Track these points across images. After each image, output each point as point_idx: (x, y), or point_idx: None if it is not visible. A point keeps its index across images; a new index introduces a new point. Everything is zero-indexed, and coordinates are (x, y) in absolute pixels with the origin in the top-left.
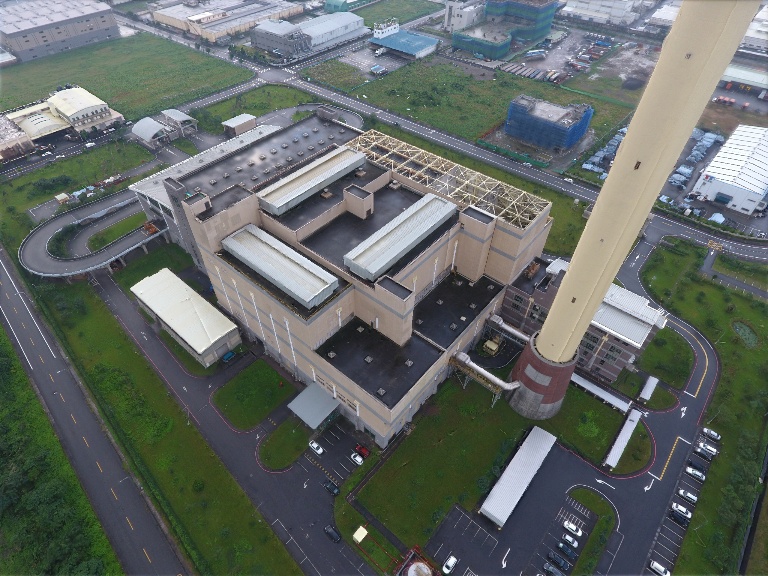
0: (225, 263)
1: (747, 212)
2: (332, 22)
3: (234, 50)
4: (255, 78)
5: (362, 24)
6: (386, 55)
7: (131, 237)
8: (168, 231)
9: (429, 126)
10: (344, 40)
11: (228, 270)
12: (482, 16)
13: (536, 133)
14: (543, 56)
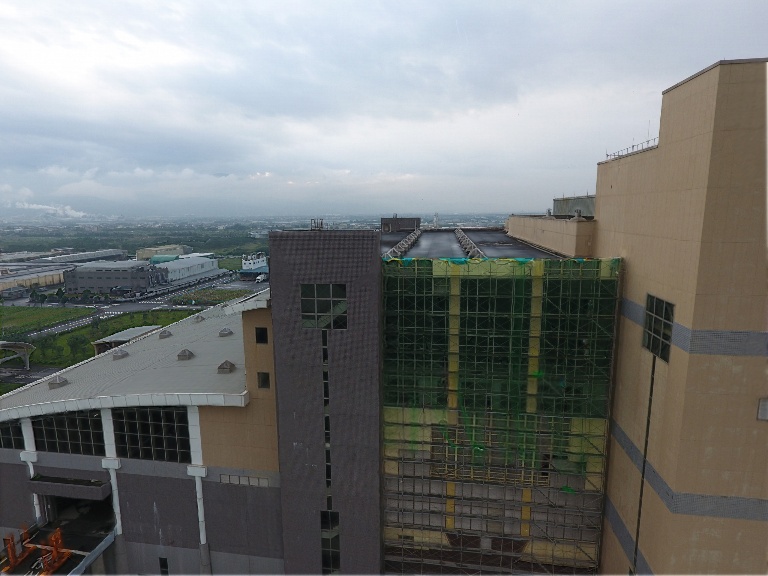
0: None
1: None
2: (183, 262)
3: None
4: (100, 312)
5: (216, 265)
6: None
7: None
8: (113, 545)
9: None
10: (204, 277)
11: None
12: None
13: None
14: None
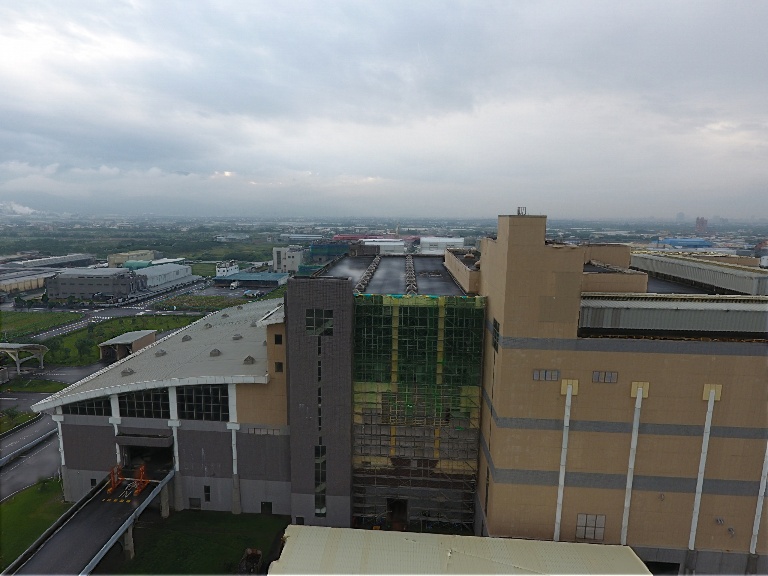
0: (626, 341)
1: None
2: (159, 268)
3: (25, 302)
4: (88, 317)
5: (190, 272)
6: (242, 287)
7: (81, 521)
8: (173, 478)
9: None
10: (180, 283)
11: (628, 361)
12: (306, 259)
13: None
14: None
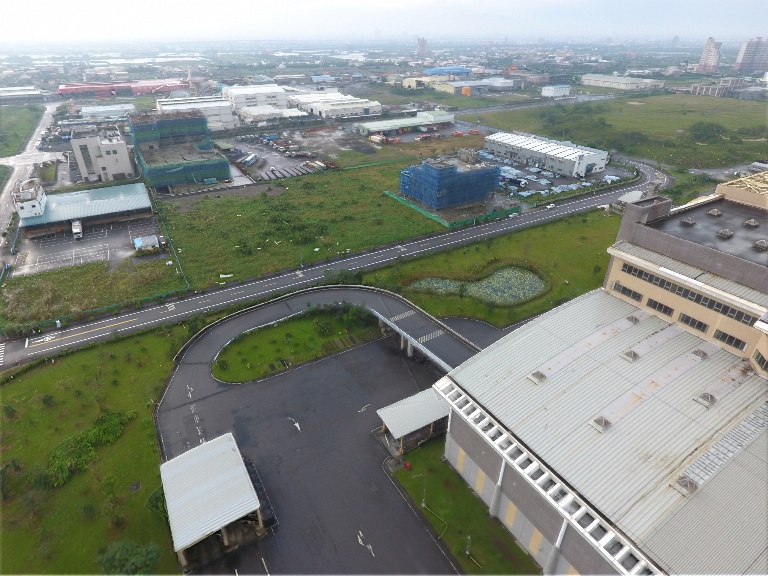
0: None
1: (602, 169)
2: None
3: None
4: None
5: None
6: (92, 230)
7: None
8: None
9: (383, 246)
10: None
11: None
12: None
13: (470, 190)
14: (264, 159)
